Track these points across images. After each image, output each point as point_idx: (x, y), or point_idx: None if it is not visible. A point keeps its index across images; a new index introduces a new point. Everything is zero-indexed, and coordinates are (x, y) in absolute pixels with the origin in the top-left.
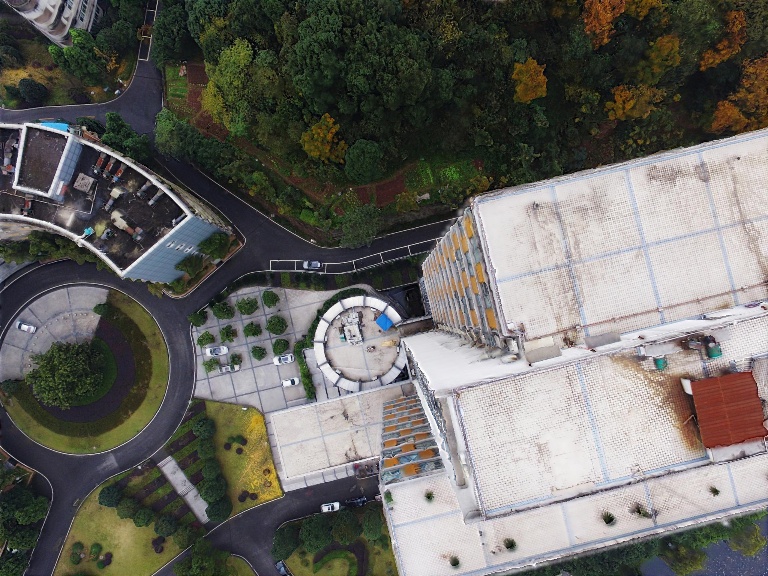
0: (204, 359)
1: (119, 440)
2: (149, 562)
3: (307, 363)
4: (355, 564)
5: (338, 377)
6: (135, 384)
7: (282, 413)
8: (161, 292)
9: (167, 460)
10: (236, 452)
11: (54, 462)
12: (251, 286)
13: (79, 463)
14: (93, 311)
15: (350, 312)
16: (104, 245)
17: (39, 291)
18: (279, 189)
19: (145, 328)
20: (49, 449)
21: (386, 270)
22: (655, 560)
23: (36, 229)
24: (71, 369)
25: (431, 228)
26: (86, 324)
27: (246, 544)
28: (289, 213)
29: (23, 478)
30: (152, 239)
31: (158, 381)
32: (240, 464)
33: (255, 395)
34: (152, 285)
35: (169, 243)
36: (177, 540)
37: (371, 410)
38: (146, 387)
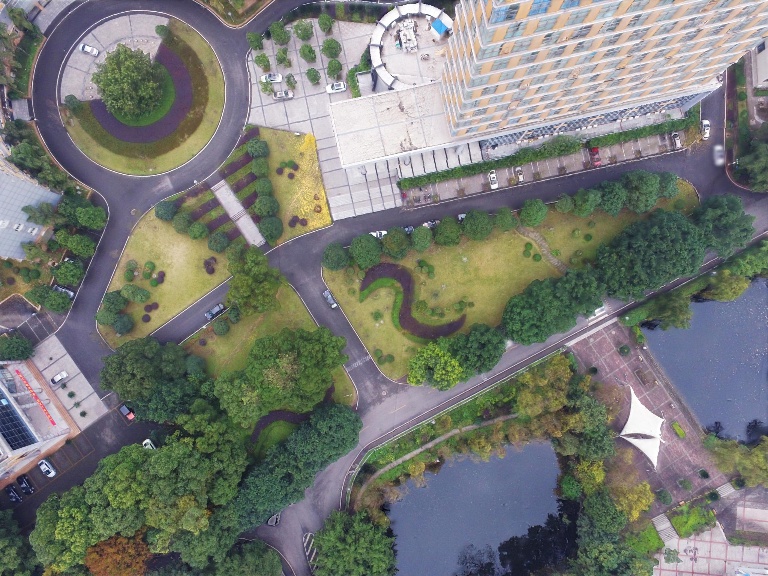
0: (259, 87)
1: (175, 163)
2: (200, 283)
3: (359, 88)
4: (401, 293)
5: (393, 79)
6: (192, 108)
7: (340, 103)
8: (222, 5)
9: (220, 185)
10: (288, 177)
11: (111, 182)
12: (306, 18)
13: (135, 184)
14: None
15: None
16: None
17: (102, 17)
18: None
19: (203, 56)
20: (107, 169)
21: None
22: (697, 307)
23: None
24: (136, 64)
25: None
26: (146, 50)
27: (295, 272)
28: None
29: (82, 193)
30: None
31: (214, 107)
32: (291, 189)
33: (307, 123)
34: None
35: None
36: (230, 253)
37: (426, 103)
38: None
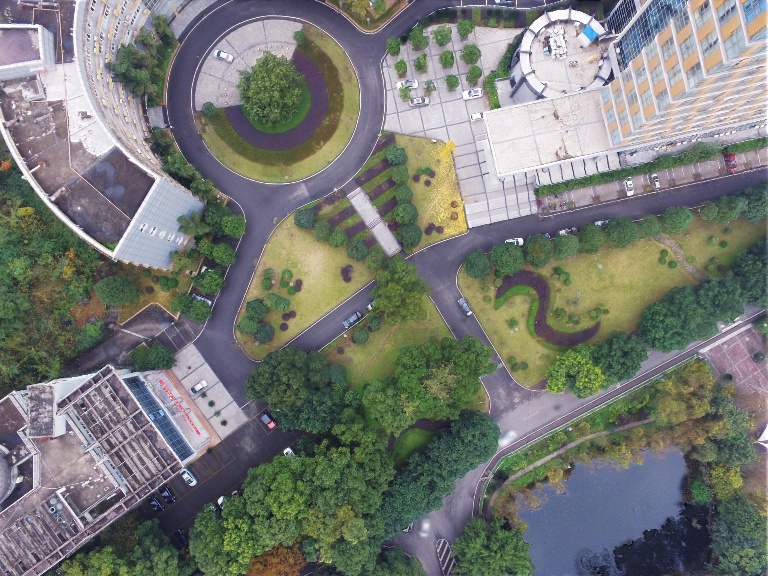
0: (394, 94)
1: (310, 170)
2: (337, 292)
3: (498, 95)
4: (537, 301)
5: (543, 86)
6: (328, 115)
7: (494, 111)
8: None
9: (356, 192)
10: (425, 184)
11: (247, 190)
12: (441, 23)
13: (271, 192)
14: (292, 38)
15: None
16: None
17: (236, 23)
18: None
19: (337, 62)
20: (243, 177)
21: (577, 4)
22: None
23: None
24: (285, 72)
25: None
26: None
27: (430, 279)
28: None
29: (220, 201)
30: None
31: (349, 114)
32: (428, 197)
33: (443, 130)
34: (359, 1)
35: None
36: (371, 261)
37: (581, 111)
38: (338, 118)
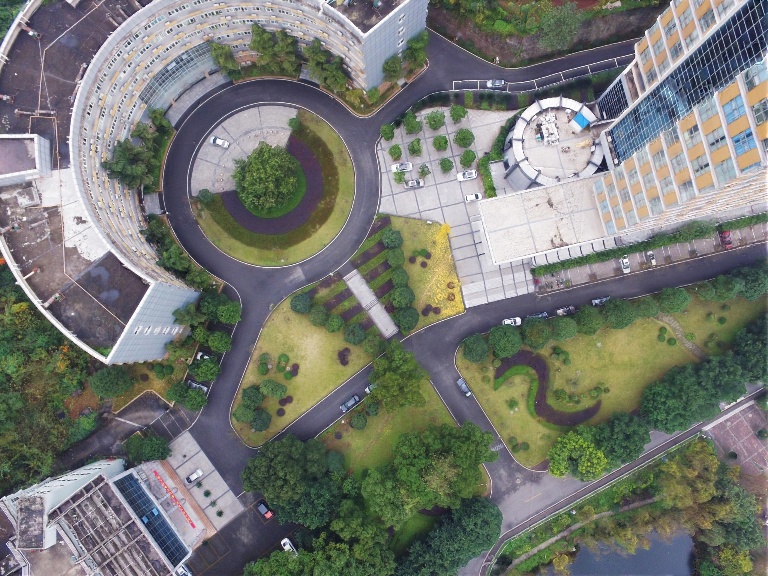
0: (389, 176)
1: (306, 253)
2: (334, 375)
3: (492, 176)
4: (536, 380)
5: (537, 173)
6: (323, 198)
7: (489, 201)
8: None
9: (352, 274)
10: (421, 265)
11: (243, 274)
12: (434, 106)
13: (267, 276)
14: None
15: (544, 114)
16: (344, 13)
17: (232, 109)
18: (473, 1)
19: (332, 146)
20: (239, 261)
21: (567, 88)
22: None
23: (261, 18)
24: (280, 163)
25: (609, 49)
26: (276, 141)
27: (428, 360)
28: (486, 20)
29: (215, 287)
30: (389, 8)
31: (345, 196)
32: (424, 278)
33: (438, 211)
34: (353, 90)
35: (402, 14)
36: (368, 346)
37: (575, 198)
38: (333, 202)
